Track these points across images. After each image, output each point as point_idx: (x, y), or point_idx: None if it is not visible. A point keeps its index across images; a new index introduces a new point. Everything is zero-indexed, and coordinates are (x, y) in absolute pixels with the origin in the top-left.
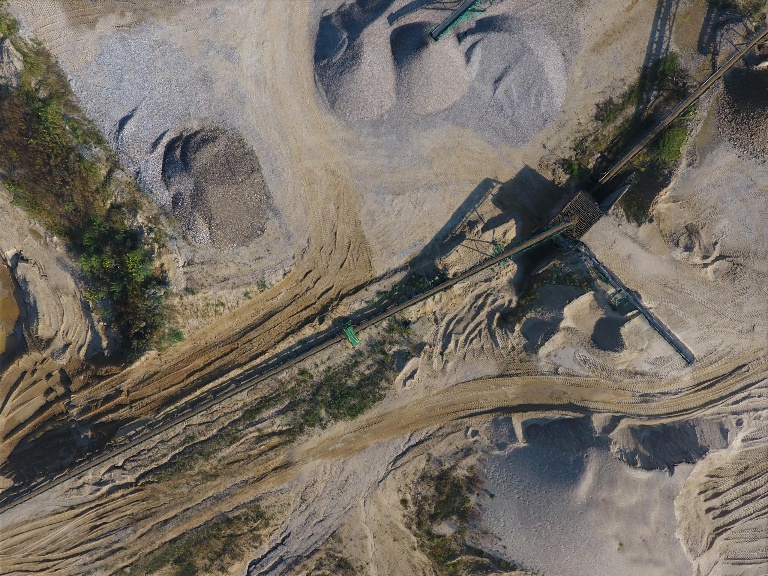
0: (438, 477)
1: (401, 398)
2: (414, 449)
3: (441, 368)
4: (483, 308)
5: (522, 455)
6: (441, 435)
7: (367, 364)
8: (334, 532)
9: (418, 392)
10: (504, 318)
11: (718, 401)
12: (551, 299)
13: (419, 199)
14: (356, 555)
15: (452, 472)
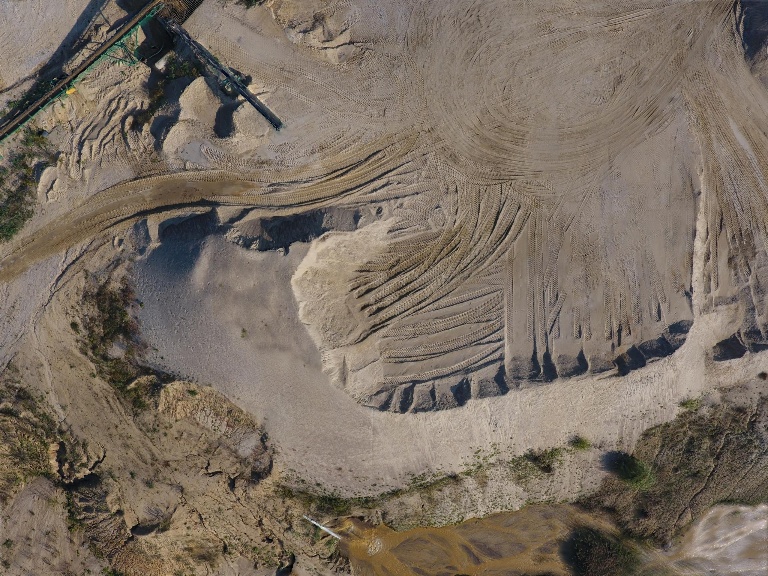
0: (97, 294)
1: (48, 213)
2: (71, 267)
3: (80, 177)
4: (115, 112)
5: (156, 255)
6: (93, 249)
7: (12, 181)
8: (9, 362)
9: (63, 205)
10: (136, 120)
11: (353, 189)
12: (173, 93)
13: (41, 4)
14: (35, 385)
15: (107, 286)
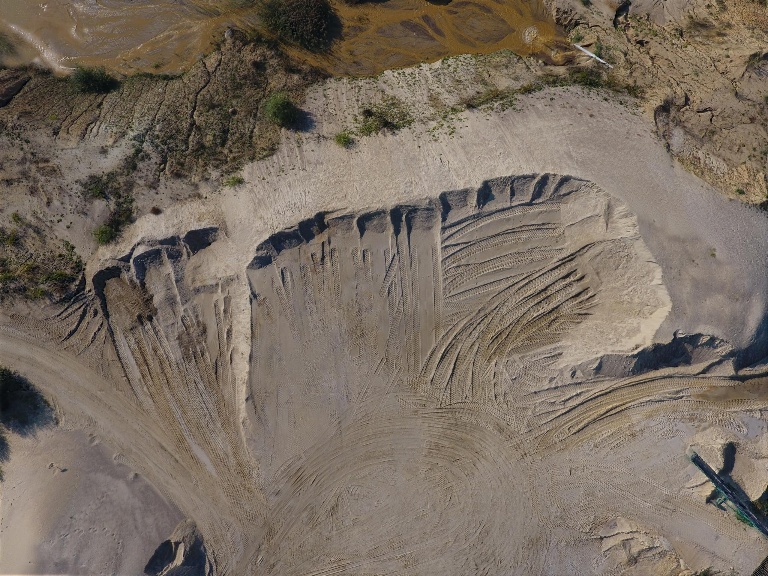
0: None
1: None
2: None
3: None
4: None
5: None
6: None
7: None
8: None
9: None
10: None
11: None
12: None
13: None
14: None
15: None
